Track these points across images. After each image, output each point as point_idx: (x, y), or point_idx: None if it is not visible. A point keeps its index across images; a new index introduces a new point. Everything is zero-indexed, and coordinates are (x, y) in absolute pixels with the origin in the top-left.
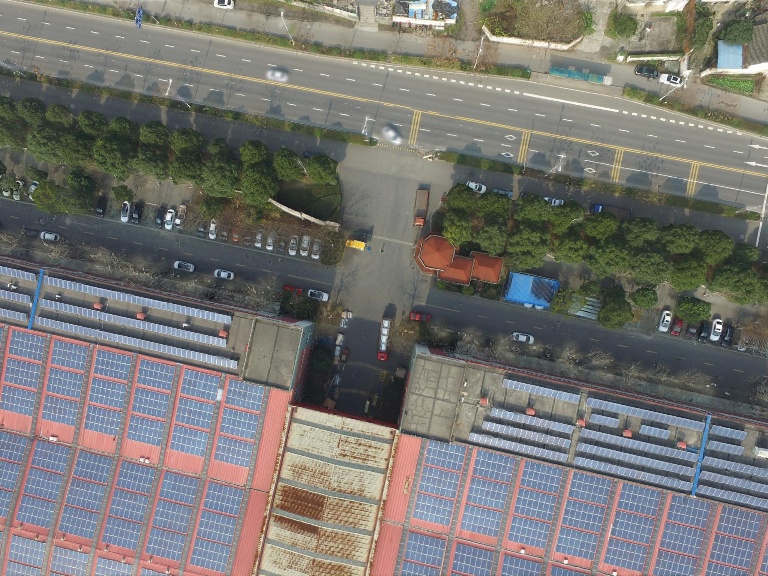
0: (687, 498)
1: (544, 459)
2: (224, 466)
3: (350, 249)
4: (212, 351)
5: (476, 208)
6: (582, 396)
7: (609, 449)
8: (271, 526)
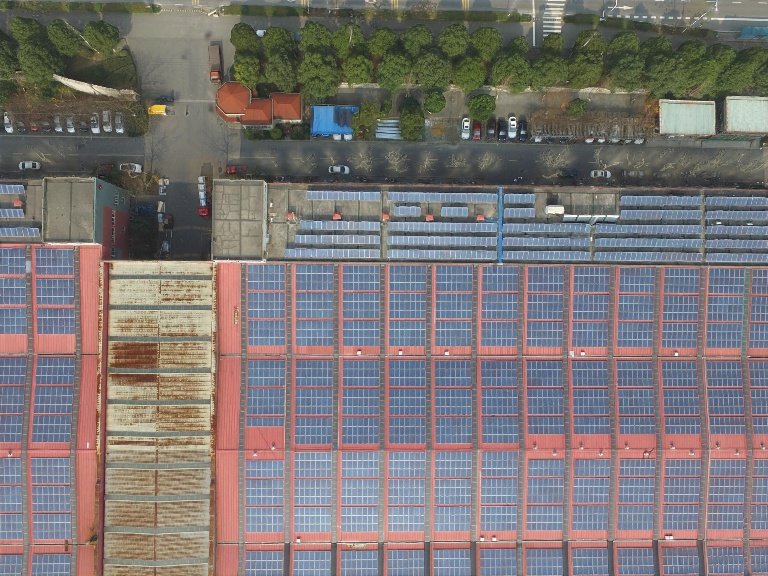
0: (496, 267)
1: (360, 260)
2: (50, 339)
3: (154, 117)
4: (12, 225)
5: (262, 48)
6: (384, 194)
7: (416, 236)
8: (109, 386)
